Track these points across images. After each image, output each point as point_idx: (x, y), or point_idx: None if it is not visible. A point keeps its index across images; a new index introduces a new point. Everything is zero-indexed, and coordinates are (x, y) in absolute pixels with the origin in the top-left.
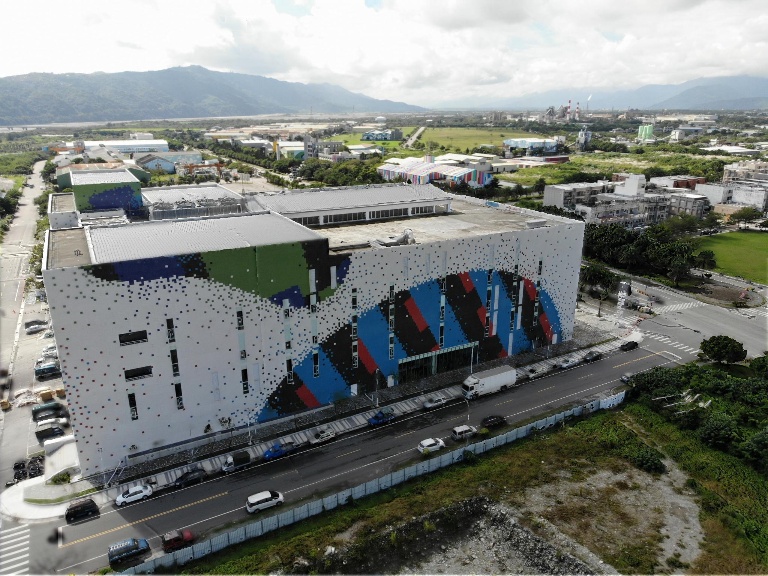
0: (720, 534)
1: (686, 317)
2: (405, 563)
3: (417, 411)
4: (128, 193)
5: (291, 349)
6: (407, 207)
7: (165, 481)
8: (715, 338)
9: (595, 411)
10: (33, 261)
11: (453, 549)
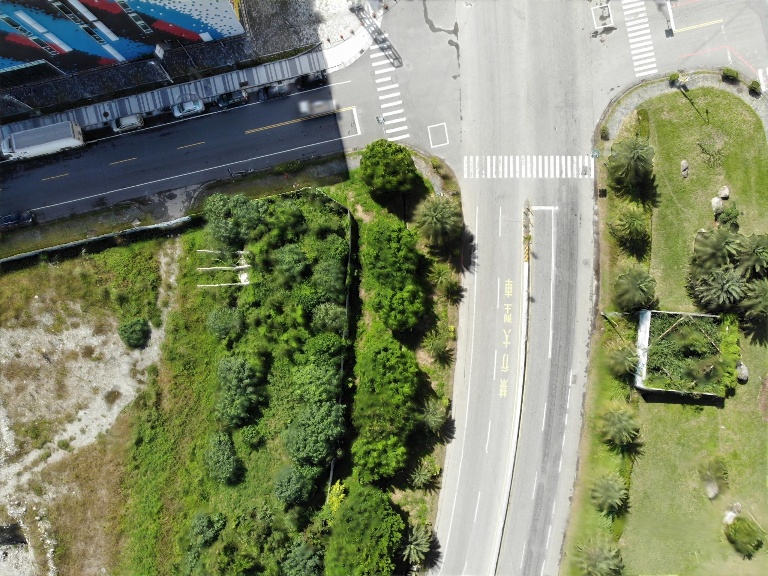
0: (122, 432)
1: (491, 2)
2: None
3: None
4: None
5: None
6: None
7: None
8: (379, 154)
9: (143, 230)
10: None
11: None
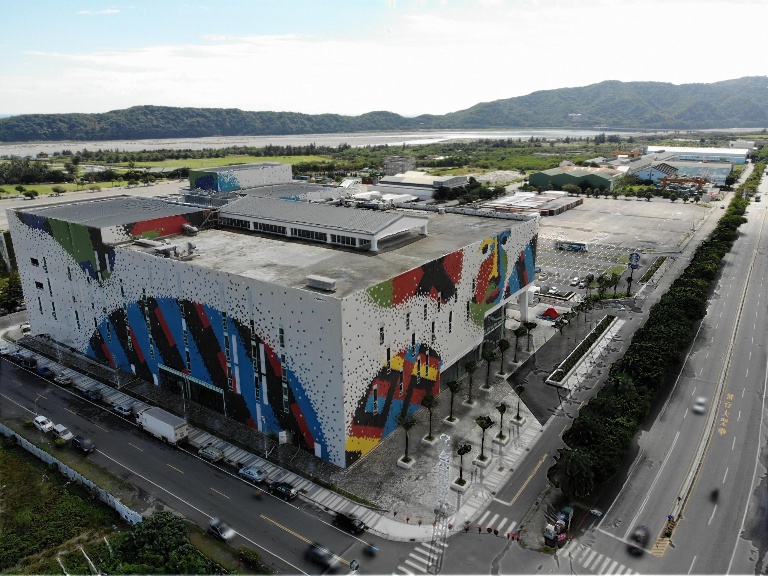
0: None
1: None
2: None
3: None
4: (212, 180)
5: (95, 310)
6: (326, 232)
7: (20, 354)
8: None
9: (111, 507)
10: None
11: None
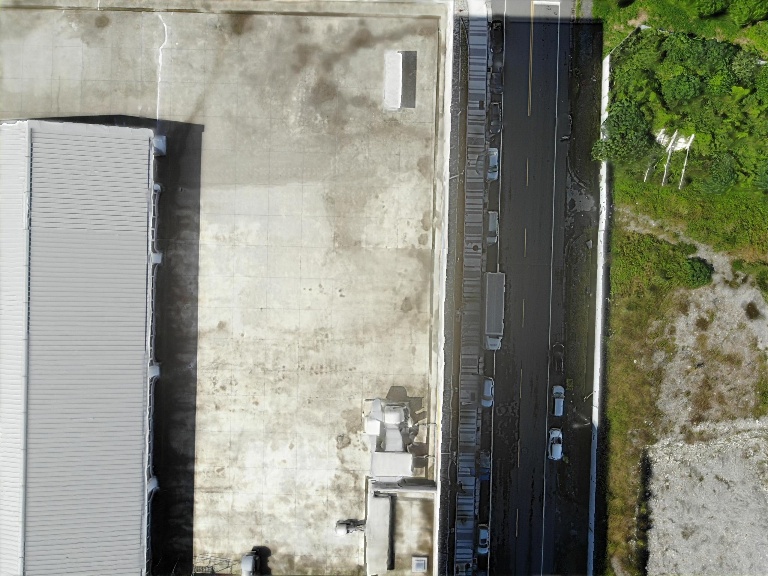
0: None
1: None
2: (645, 530)
3: (484, 415)
4: None
5: None
6: None
7: None
8: None
9: None
10: None
11: (652, 487)
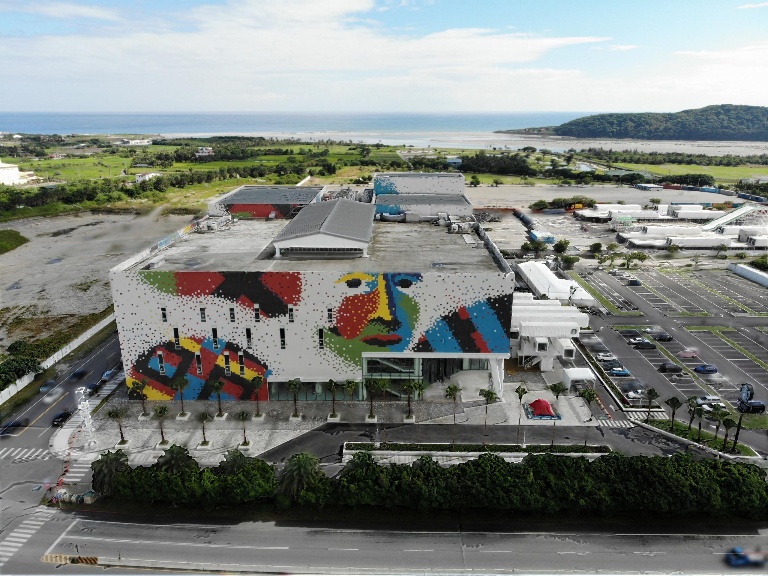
0: None
1: None
2: None
3: None
4: None
5: None
6: None
7: None
8: None
9: (65, 355)
10: (623, 263)
11: None
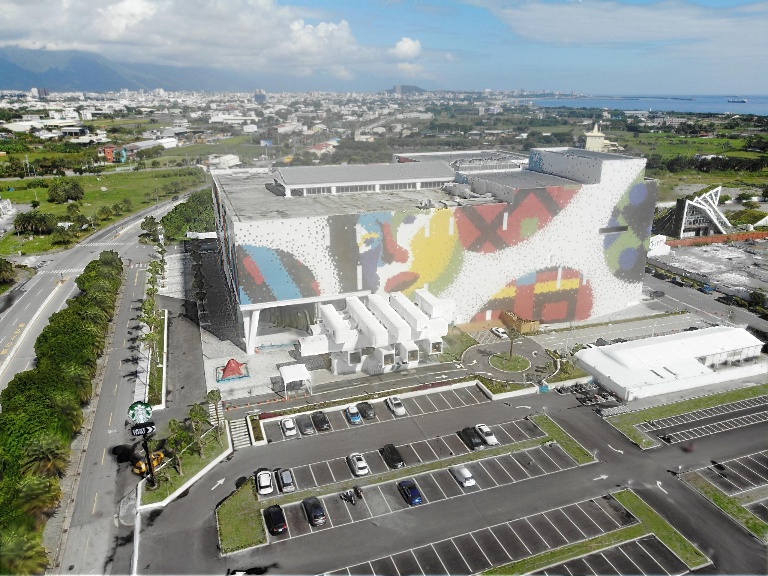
0: None
1: None
2: None
3: None
4: None
5: None
6: None
7: None
8: None
9: None
10: None
11: None
